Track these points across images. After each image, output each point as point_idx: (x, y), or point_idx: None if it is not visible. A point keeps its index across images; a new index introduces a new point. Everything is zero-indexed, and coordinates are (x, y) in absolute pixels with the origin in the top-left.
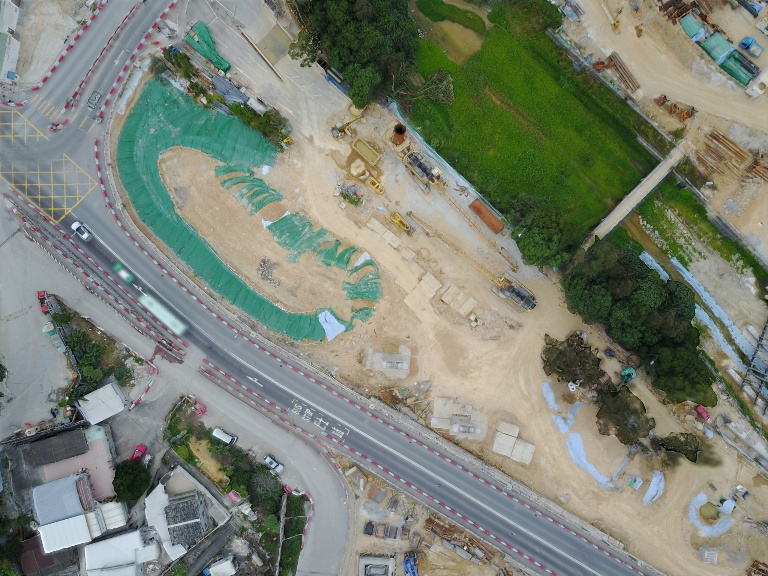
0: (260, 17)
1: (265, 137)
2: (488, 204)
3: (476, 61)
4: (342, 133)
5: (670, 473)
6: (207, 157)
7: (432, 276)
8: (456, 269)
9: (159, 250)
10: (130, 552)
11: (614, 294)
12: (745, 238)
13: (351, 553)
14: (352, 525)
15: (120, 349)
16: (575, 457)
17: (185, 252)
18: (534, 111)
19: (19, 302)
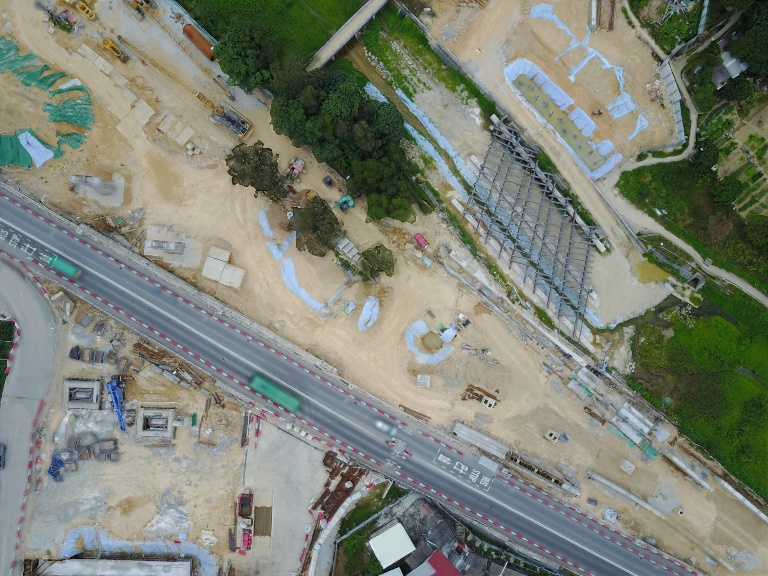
0: None
1: None
2: (203, 31)
3: None
4: None
5: (388, 300)
6: None
7: (145, 103)
8: (173, 98)
9: None
10: None
11: (307, 107)
12: (463, 65)
13: (58, 378)
14: (59, 350)
15: None
16: (289, 283)
17: None
18: None
19: None
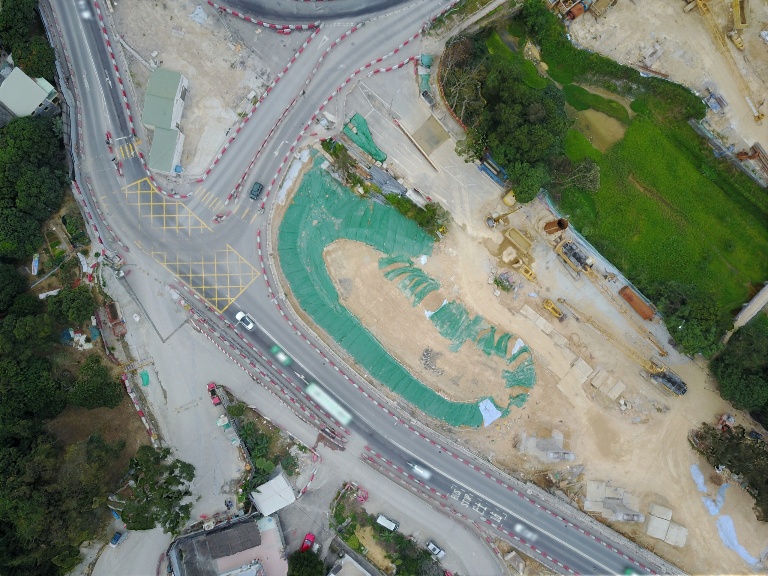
0: (415, 109)
1: (422, 226)
2: (637, 290)
3: (620, 149)
4: (497, 223)
5: None
6: (371, 249)
7: (584, 361)
8: (605, 353)
9: (320, 339)
10: None
11: None
12: None
13: None
14: None
15: (284, 437)
16: (725, 539)
17: (346, 341)
18: (677, 198)
19: (189, 394)
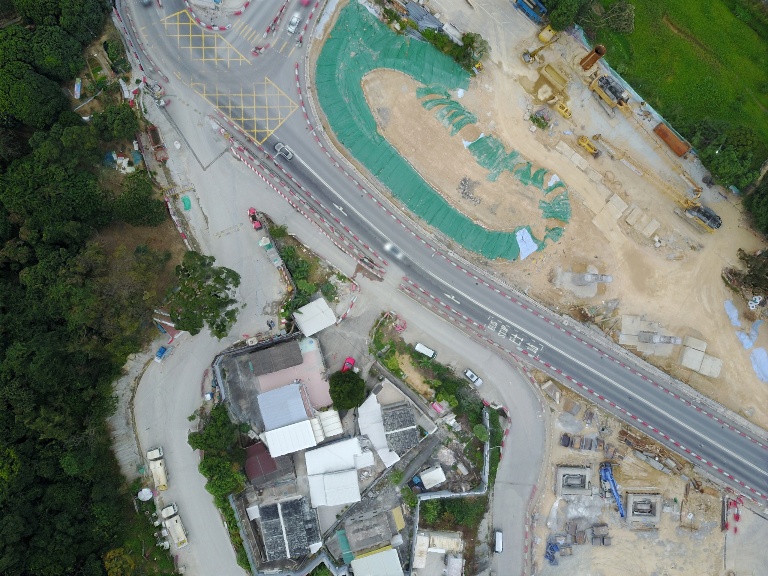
0: None
1: (458, 62)
2: (671, 128)
3: None
4: (533, 58)
5: None
6: (409, 79)
7: (619, 197)
8: (639, 192)
9: (358, 171)
10: (349, 458)
11: None
12: None
13: (547, 464)
14: (548, 437)
15: (323, 267)
16: (759, 371)
17: (384, 173)
18: (711, 39)
19: (230, 219)
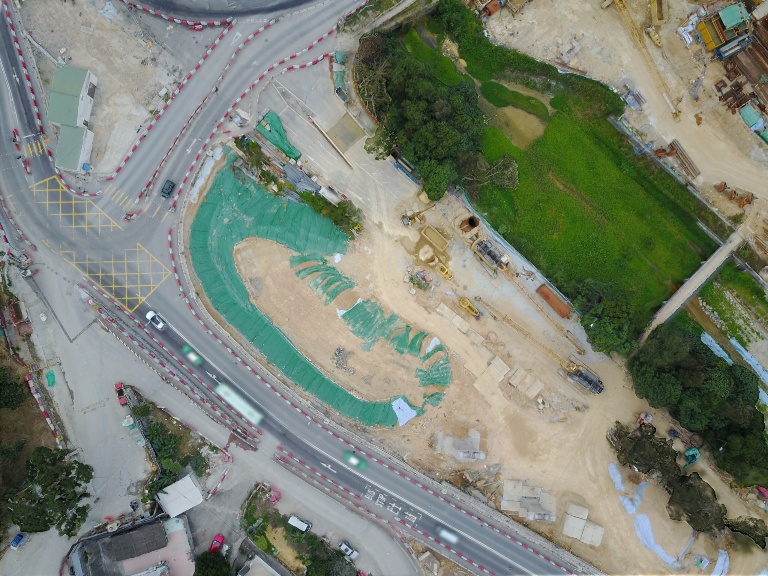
0: (330, 106)
1: (336, 225)
2: (554, 289)
3: (540, 147)
4: (412, 220)
5: (734, 551)
6: (282, 247)
7: (501, 360)
8: (523, 352)
9: (233, 338)
10: None
11: (684, 383)
12: None
13: None
14: None
15: (195, 438)
16: (642, 538)
17: (259, 340)
18: (596, 195)
19: (96, 394)
